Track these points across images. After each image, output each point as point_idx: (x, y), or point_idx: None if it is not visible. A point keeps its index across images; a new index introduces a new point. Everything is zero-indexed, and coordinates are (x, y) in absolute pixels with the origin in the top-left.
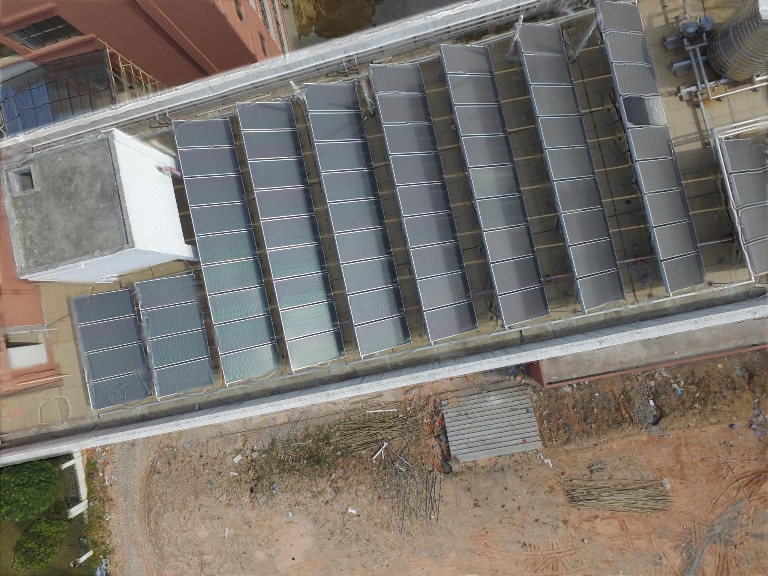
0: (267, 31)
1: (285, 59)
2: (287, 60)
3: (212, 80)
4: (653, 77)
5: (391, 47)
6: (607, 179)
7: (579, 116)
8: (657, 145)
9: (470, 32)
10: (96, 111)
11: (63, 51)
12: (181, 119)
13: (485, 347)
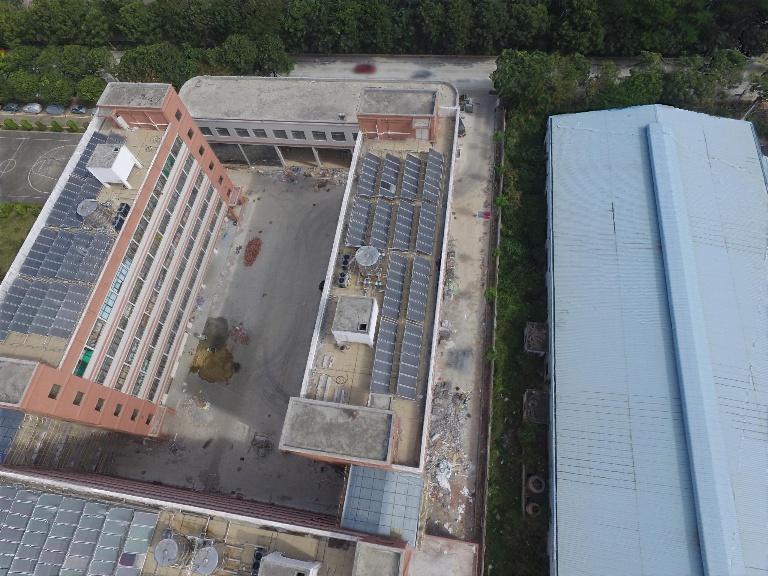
0: (138, 392)
1: (44, 480)
2: (44, 481)
3: (19, 475)
4: (149, 545)
5: (78, 492)
6: None
7: (115, 550)
8: (131, 575)
9: (106, 497)
10: (6, 437)
11: (9, 409)
12: (5, 481)
13: None
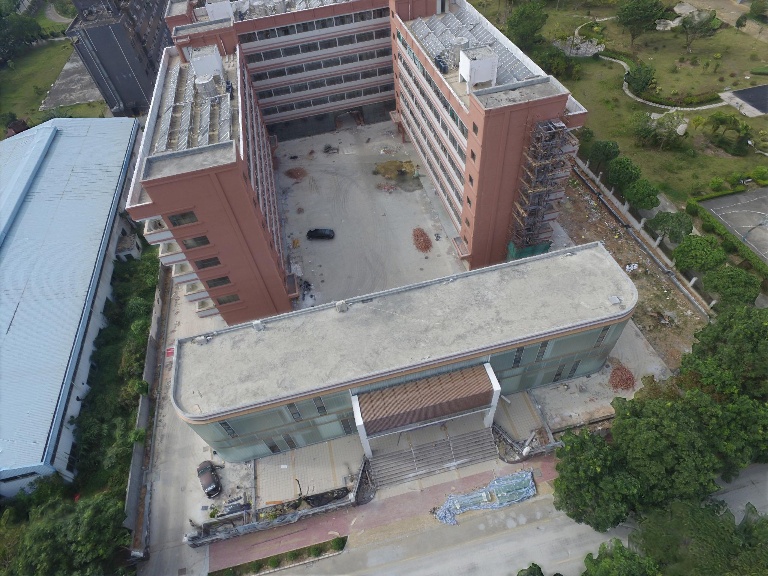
0: None
1: None
2: None
3: None
4: None
5: None
6: None
7: (311, 4)
8: None
9: None
10: None
11: None
12: None
13: None
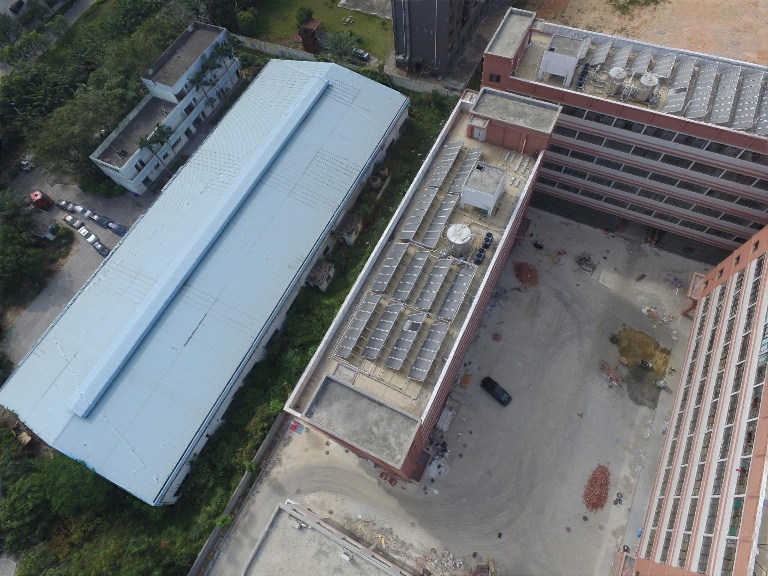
0: None
1: None
2: None
3: None
4: None
5: None
6: (688, 90)
7: None
8: None
9: None
10: None
11: None
12: None
13: (749, 67)
